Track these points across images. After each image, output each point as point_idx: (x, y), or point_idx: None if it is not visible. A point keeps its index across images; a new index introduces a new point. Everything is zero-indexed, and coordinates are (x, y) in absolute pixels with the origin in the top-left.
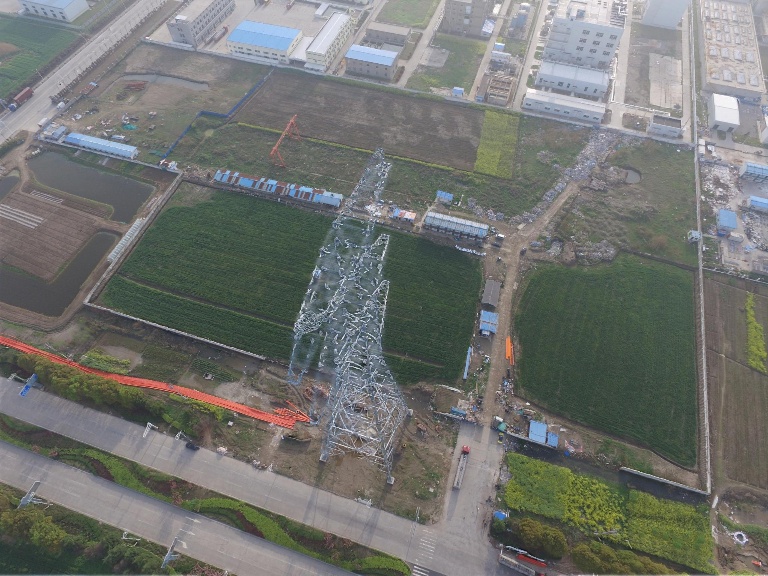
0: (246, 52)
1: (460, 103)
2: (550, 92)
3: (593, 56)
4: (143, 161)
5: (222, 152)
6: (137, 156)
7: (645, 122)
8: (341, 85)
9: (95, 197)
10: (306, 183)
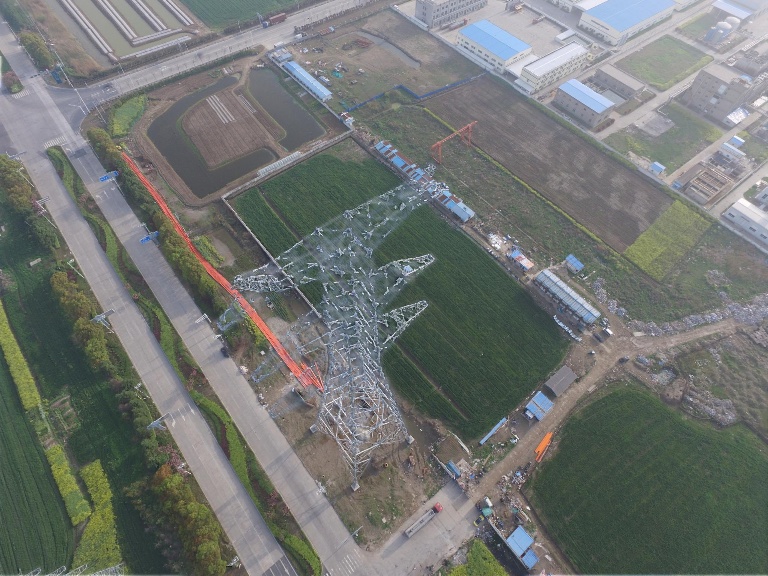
0: (470, 48)
1: (652, 180)
2: None
3: None
4: (330, 107)
5: (396, 127)
6: (328, 101)
7: None
8: (539, 112)
9: (279, 119)
10: (450, 187)
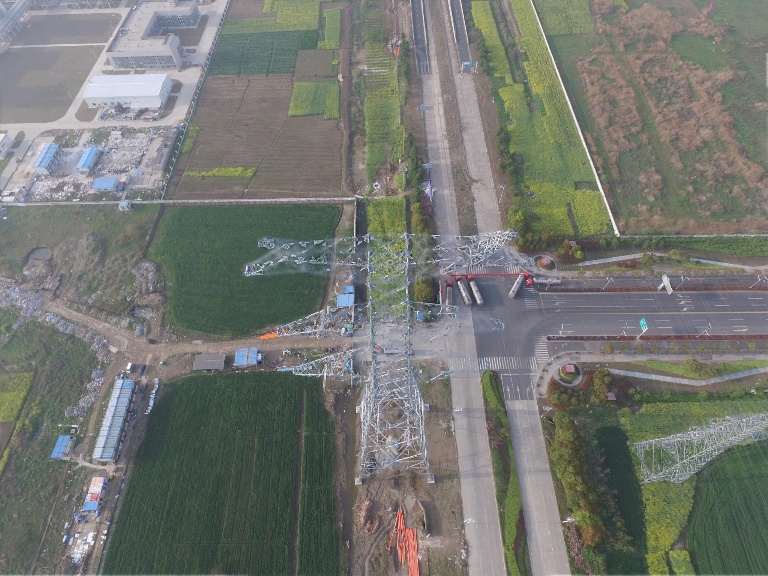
0: None
1: None
2: None
3: None
4: None
5: None
6: None
7: None
8: None
9: None
10: None
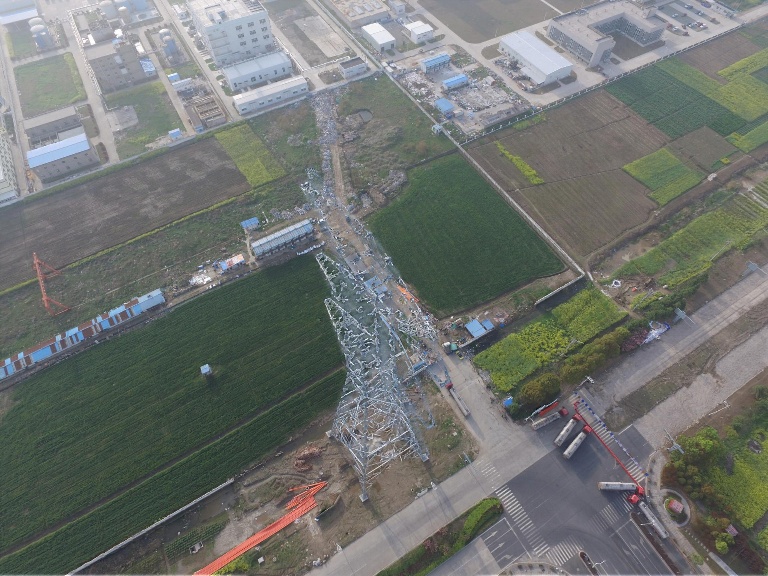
0: None
1: (186, 142)
2: (251, 90)
3: (257, 44)
4: None
5: None
6: None
7: (337, 72)
8: (50, 197)
9: None
10: (109, 306)
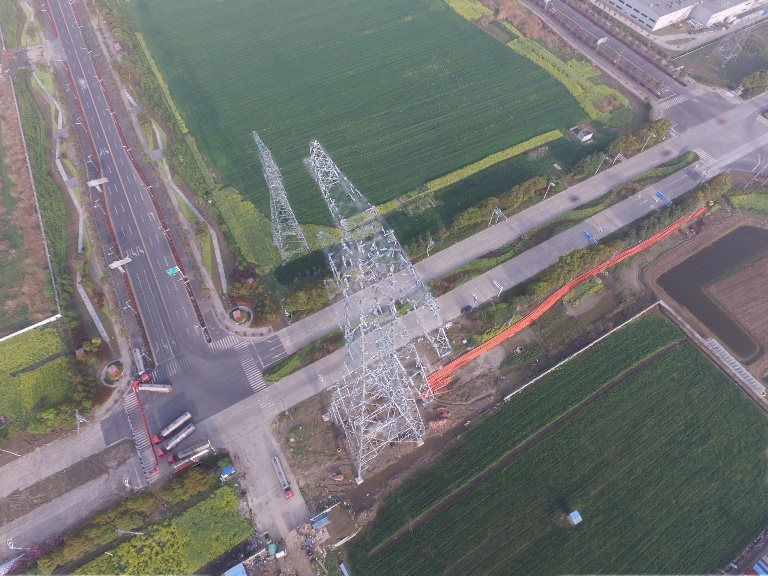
0: None
1: None
2: None
3: None
4: None
5: None
6: None
7: None
8: None
9: None
10: None
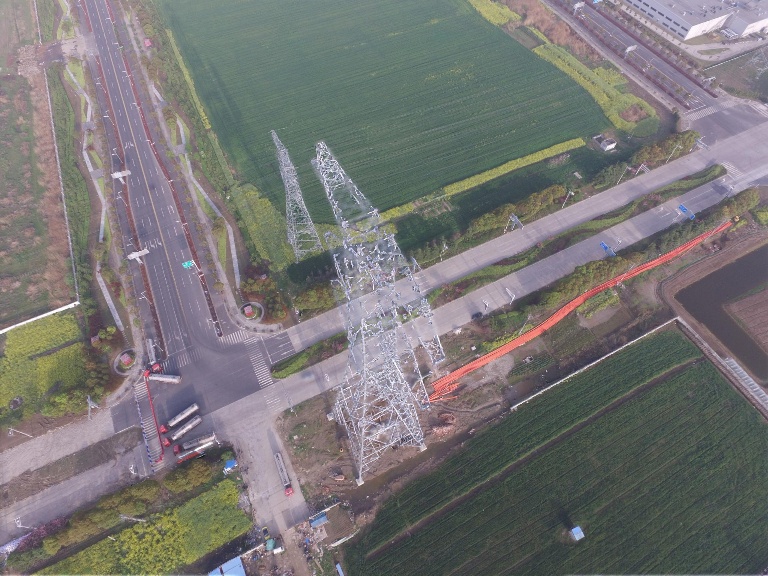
0: None
1: None
2: None
3: None
4: None
5: None
6: None
7: None
8: None
9: None
10: None
